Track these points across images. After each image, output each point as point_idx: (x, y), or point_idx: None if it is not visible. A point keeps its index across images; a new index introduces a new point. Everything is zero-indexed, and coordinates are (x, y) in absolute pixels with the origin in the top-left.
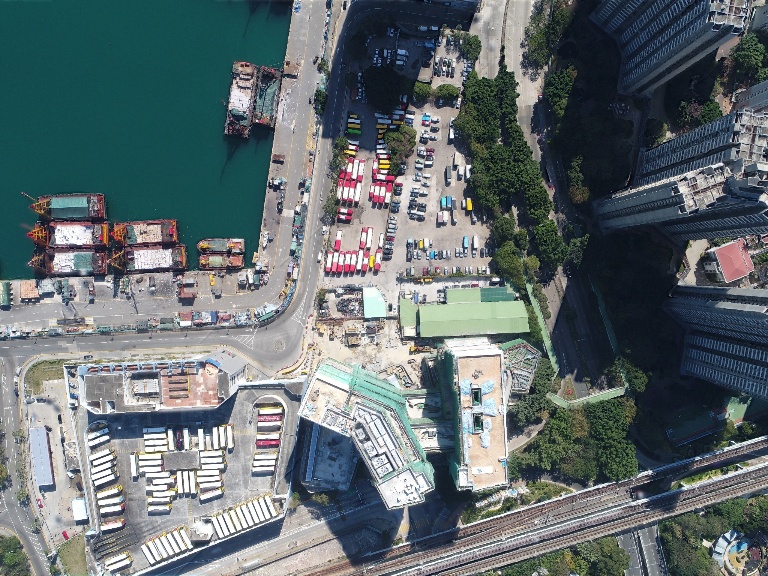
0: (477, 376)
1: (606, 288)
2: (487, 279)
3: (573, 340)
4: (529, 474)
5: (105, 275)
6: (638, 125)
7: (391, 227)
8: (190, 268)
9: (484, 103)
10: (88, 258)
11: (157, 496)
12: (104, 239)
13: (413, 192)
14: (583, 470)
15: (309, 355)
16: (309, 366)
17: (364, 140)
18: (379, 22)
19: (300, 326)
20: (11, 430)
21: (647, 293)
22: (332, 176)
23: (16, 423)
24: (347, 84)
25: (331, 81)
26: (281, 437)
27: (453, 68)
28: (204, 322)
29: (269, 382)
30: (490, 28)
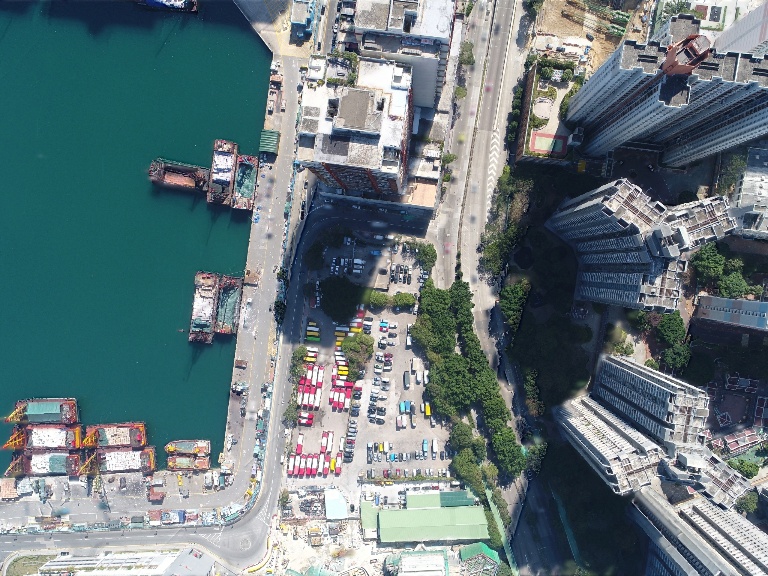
0: None
1: (565, 498)
2: (447, 481)
3: (535, 543)
4: None
5: (79, 475)
6: (598, 328)
7: (351, 431)
8: (159, 468)
9: (438, 316)
10: (62, 461)
11: None
12: (77, 444)
13: (372, 396)
14: None
15: (274, 554)
16: (274, 564)
17: (323, 346)
18: (335, 234)
19: (265, 525)
20: None
21: (607, 504)
22: (293, 380)
23: None
24: (305, 295)
25: (290, 289)
26: None
27: (409, 275)
28: (172, 522)
29: None
30: (446, 234)
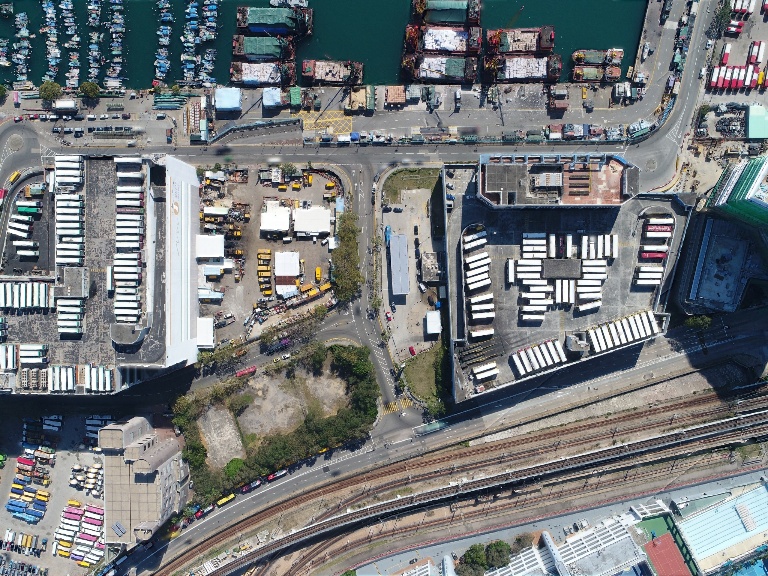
0: None
1: None
2: None
3: None
4: None
5: (472, 84)
6: None
7: None
8: (561, 80)
9: None
10: (460, 63)
11: (534, 304)
12: (480, 43)
13: None
14: None
15: (682, 176)
16: (682, 188)
17: None
18: None
19: (675, 145)
20: (364, 239)
21: None
22: None
23: (370, 232)
24: None
25: None
26: (669, 250)
27: None
28: (575, 135)
29: (657, 192)
30: None
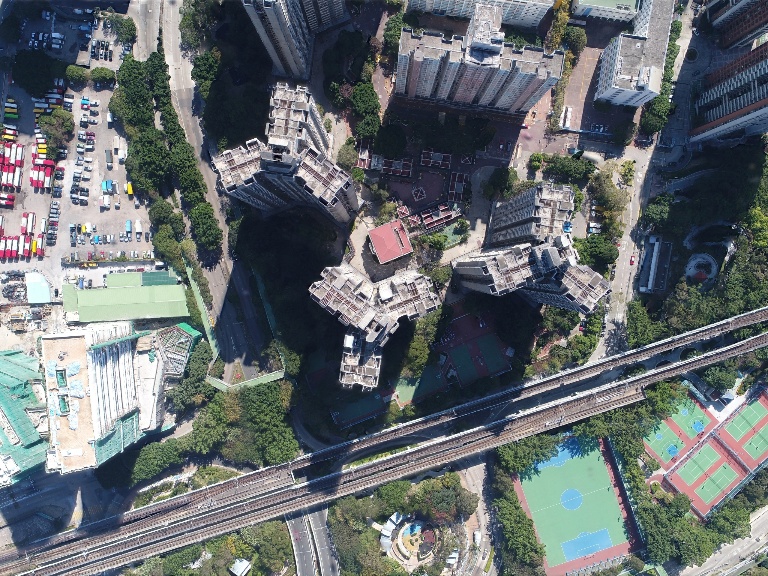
0: (62, 357)
1: None
2: (153, 263)
3: (240, 324)
4: (200, 459)
5: None
6: None
7: (53, 212)
8: None
9: (131, 85)
10: None
11: None
12: None
13: (74, 176)
14: (244, 454)
15: None
16: None
17: (24, 124)
18: (30, 5)
19: None
20: None
21: (300, 275)
22: None
23: None
24: None
25: None
26: None
27: (110, 51)
28: None
29: None
30: (148, 10)
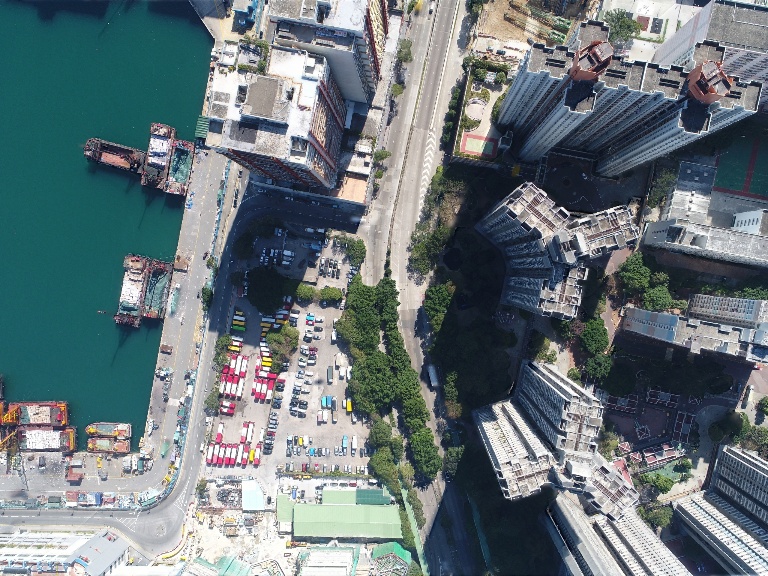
0: None
1: (479, 502)
2: (365, 479)
3: (449, 545)
4: None
5: None
6: (523, 334)
7: (272, 423)
8: (79, 449)
9: (362, 312)
10: None
11: None
12: None
13: (295, 389)
14: None
15: (189, 541)
16: (188, 552)
17: (249, 336)
18: (265, 224)
19: (181, 512)
20: None
21: (520, 511)
22: (217, 369)
23: None
24: (232, 283)
25: (219, 277)
26: None
27: (338, 270)
28: (89, 504)
29: (141, 575)
30: (377, 231)
